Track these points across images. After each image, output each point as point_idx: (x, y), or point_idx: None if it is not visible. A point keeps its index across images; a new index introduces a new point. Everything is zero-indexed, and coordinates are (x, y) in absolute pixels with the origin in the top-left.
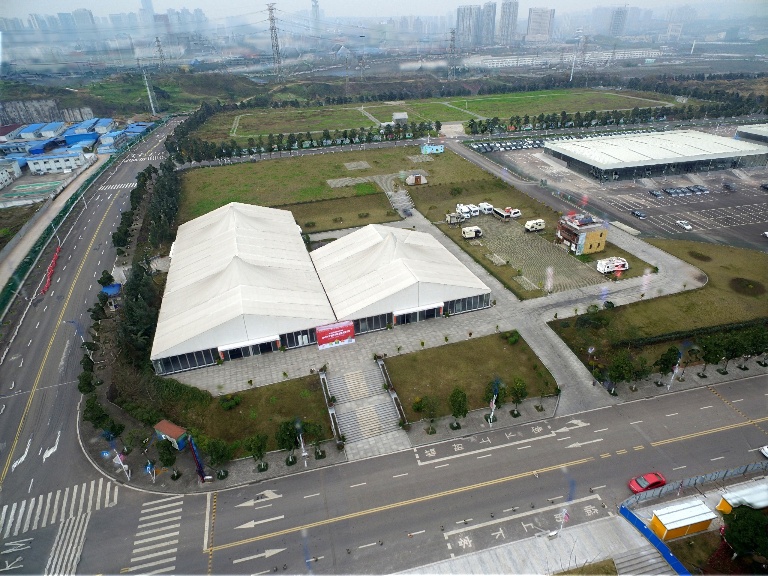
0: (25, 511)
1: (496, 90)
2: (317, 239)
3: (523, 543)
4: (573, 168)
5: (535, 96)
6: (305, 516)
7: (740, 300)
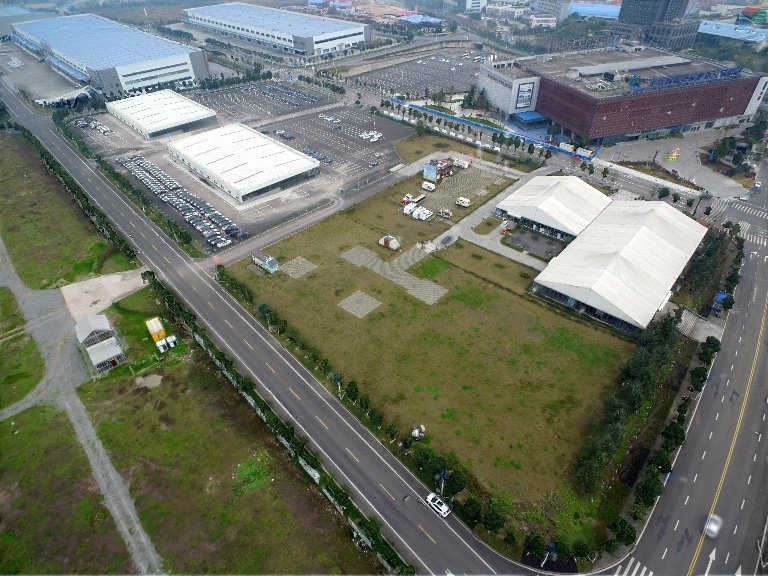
0: (760, 242)
1: None
2: (539, 262)
3: (618, 169)
4: (289, 186)
5: None
6: (666, 196)
7: None
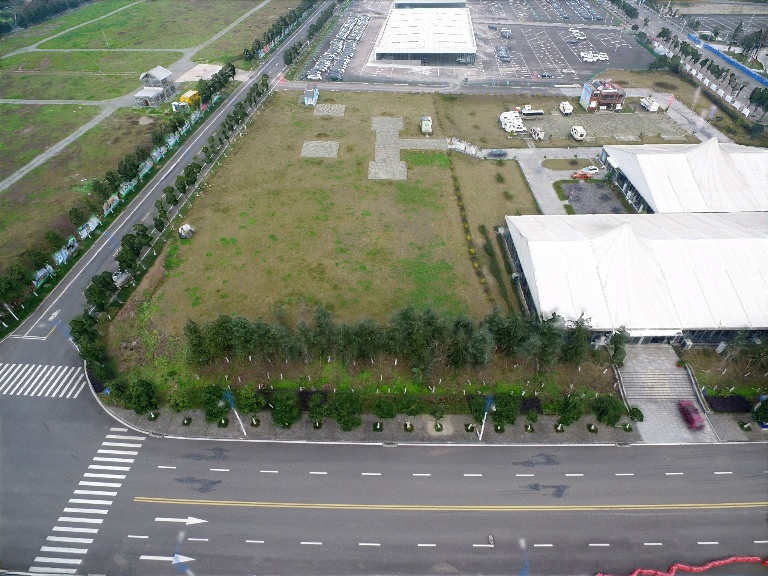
0: None
1: (40, 15)
2: None
3: None
4: (431, 63)
5: (114, 12)
6: None
7: (683, 92)
